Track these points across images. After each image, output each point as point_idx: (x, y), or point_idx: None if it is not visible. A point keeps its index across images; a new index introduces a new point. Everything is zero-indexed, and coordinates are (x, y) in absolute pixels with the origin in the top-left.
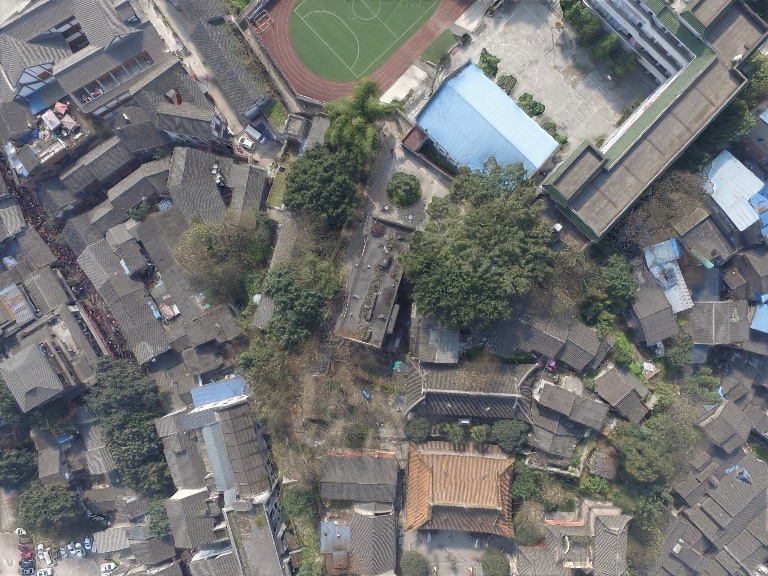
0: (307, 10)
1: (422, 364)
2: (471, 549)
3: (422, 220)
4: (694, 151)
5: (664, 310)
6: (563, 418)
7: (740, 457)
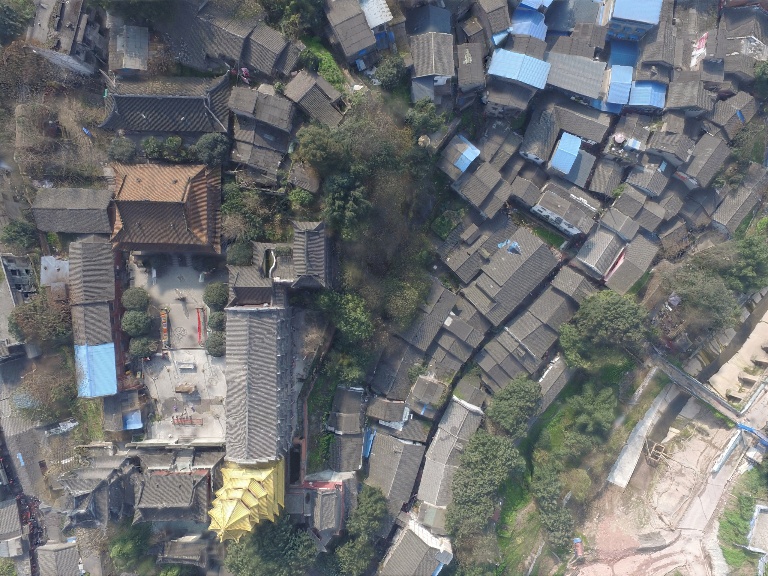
0: None
1: (119, 79)
2: (201, 289)
3: None
4: None
5: (356, 16)
6: (260, 128)
7: (512, 231)
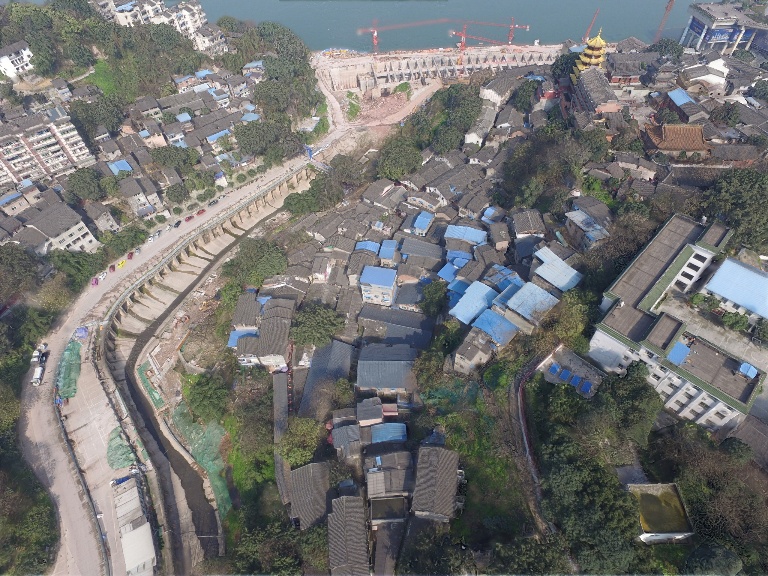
0: None
1: None
2: None
3: (766, 267)
4: (605, 278)
5: None
6: None
7: None
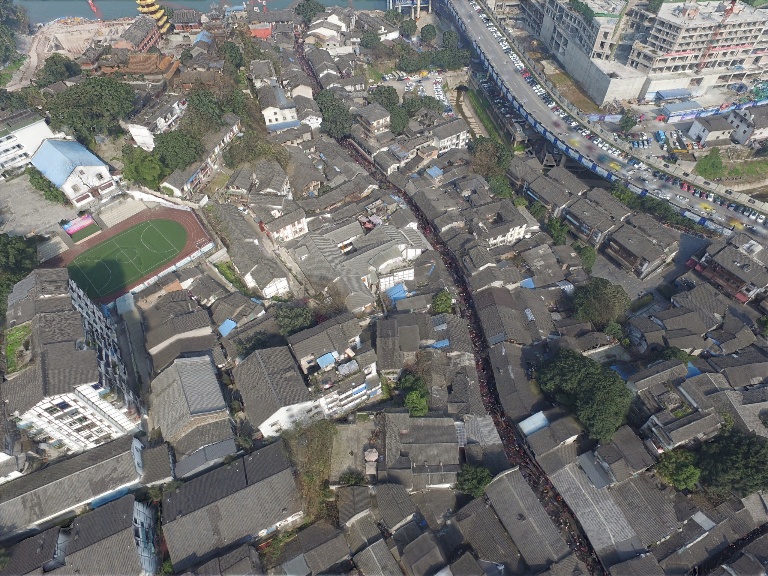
0: (170, 252)
1: None
2: None
3: None
4: None
5: None
6: None
7: None
